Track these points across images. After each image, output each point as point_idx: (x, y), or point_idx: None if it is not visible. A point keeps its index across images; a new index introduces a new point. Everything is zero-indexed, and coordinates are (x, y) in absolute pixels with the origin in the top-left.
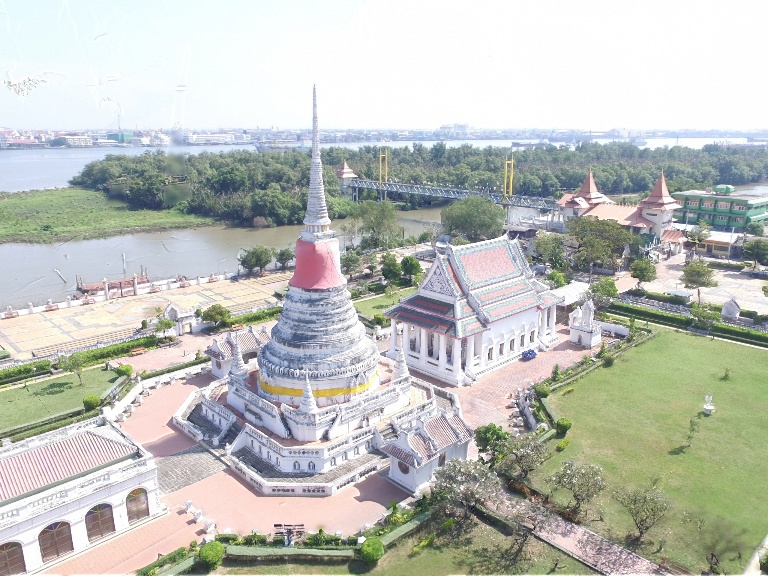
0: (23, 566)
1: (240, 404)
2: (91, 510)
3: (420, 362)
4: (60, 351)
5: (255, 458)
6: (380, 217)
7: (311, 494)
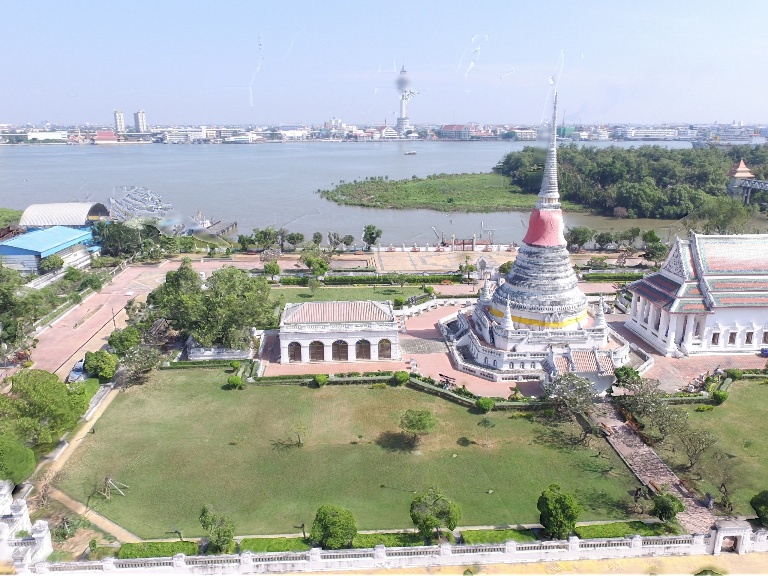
0: (323, 357)
1: (476, 319)
2: (360, 341)
3: (646, 332)
4: (401, 272)
5: (468, 352)
6: (728, 216)
7: (485, 377)
